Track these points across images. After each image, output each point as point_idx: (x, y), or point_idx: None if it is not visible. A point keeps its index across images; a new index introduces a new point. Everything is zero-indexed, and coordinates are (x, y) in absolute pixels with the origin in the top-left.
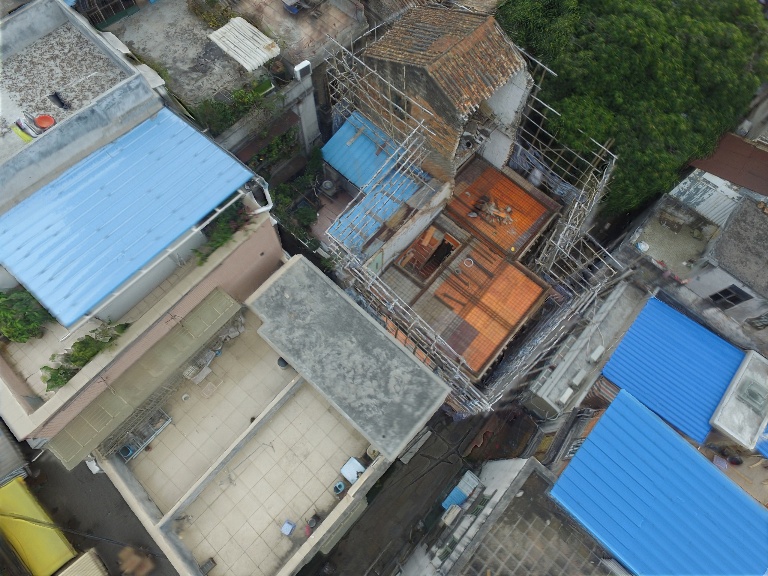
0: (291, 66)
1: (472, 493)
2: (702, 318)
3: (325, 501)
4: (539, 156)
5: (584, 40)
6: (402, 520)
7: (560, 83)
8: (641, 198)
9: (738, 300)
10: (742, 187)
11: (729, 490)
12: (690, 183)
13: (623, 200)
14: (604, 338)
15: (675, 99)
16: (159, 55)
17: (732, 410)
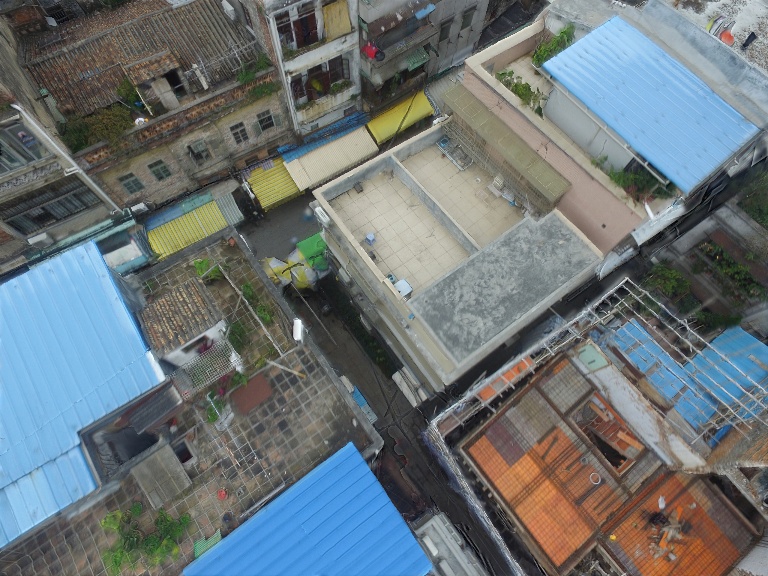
0: None
1: None
2: None
3: (383, 269)
4: None
5: None
6: None
7: None
8: None
9: None
10: None
11: None
12: None
13: None
14: None
15: None
16: None
17: None
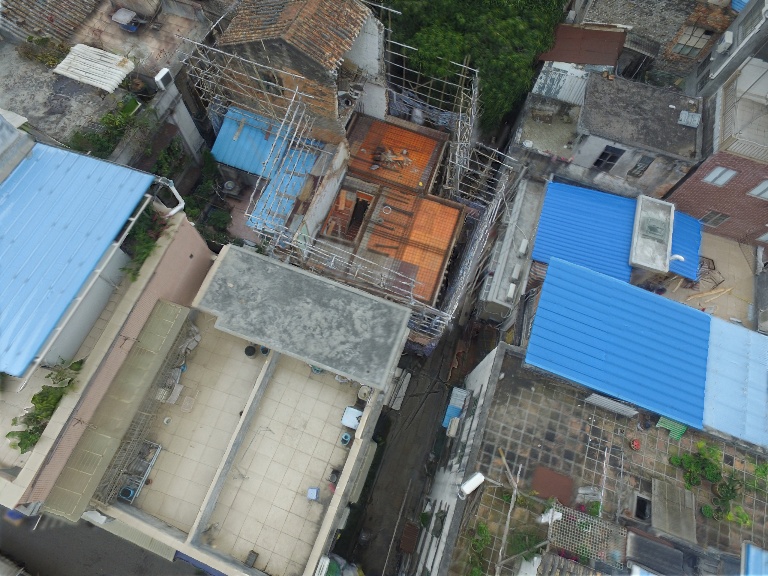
0: (150, 80)
1: (464, 404)
2: (595, 186)
3: (338, 456)
4: (413, 95)
5: None
6: (414, 465)
7: (407, 21)
8: (510, 101)
9: (615, 158)
10: (585, 64)
11: (660, 304)
12: (545, 76)
13: (496, 107)
14: (525, 233)
15: (506, 5)
16: None
17: (642, 248)
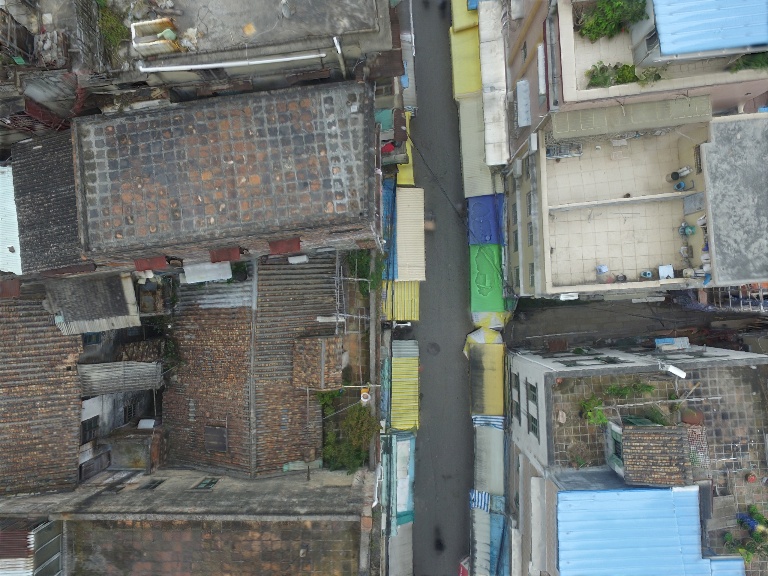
0: None
1: (682, 349)
2: None
3: (630, 274)
4: None
5: None
6: None
7: None
8: None
9: None
10: None
11: None
12: None
13: None
14: None
15: None
16: None
17: None
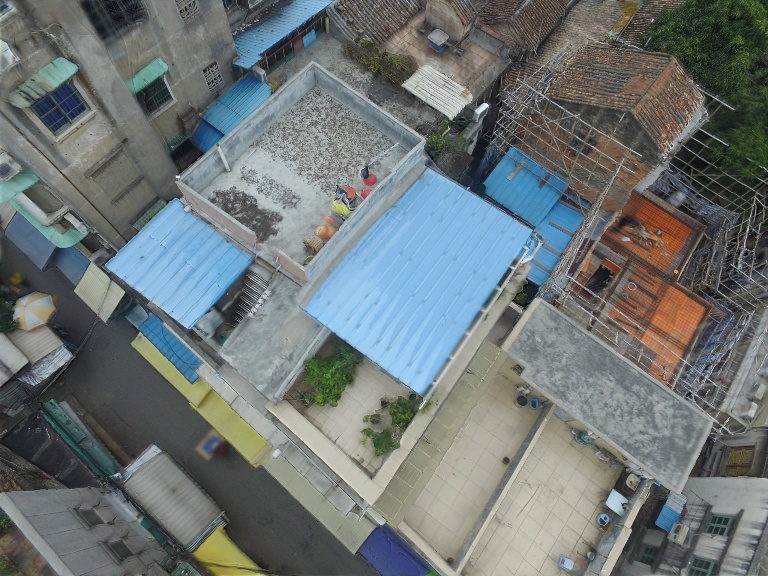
0: None
1: (685, 510)
2: None
3: (590, 533)
4: (687, 180)
5: (757, 75)
6: None
7: (724, 114)
8: None
9: None
10: None
11: None
12: None
13: None
14: None
15: None
16: None
17: None
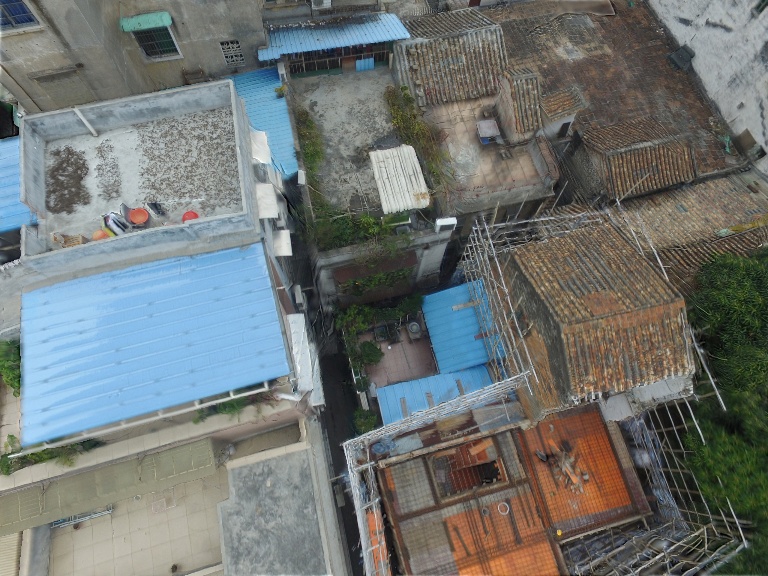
0: (440, 209)
1: None
2: None
3: None
4: (657, 446)
5: None
6: None
7: None
8: None
9: None
10: None
11: None
12: None
13: None
14: None
15: None
16: (330, 128)
17: None
